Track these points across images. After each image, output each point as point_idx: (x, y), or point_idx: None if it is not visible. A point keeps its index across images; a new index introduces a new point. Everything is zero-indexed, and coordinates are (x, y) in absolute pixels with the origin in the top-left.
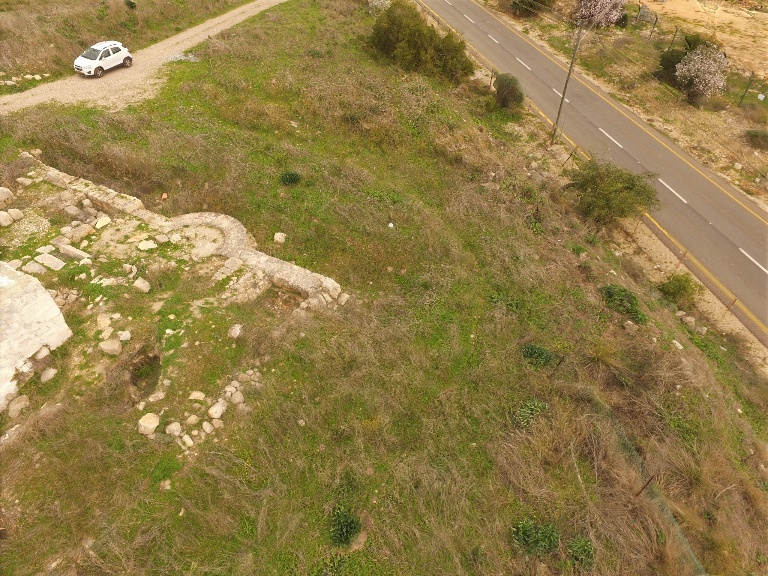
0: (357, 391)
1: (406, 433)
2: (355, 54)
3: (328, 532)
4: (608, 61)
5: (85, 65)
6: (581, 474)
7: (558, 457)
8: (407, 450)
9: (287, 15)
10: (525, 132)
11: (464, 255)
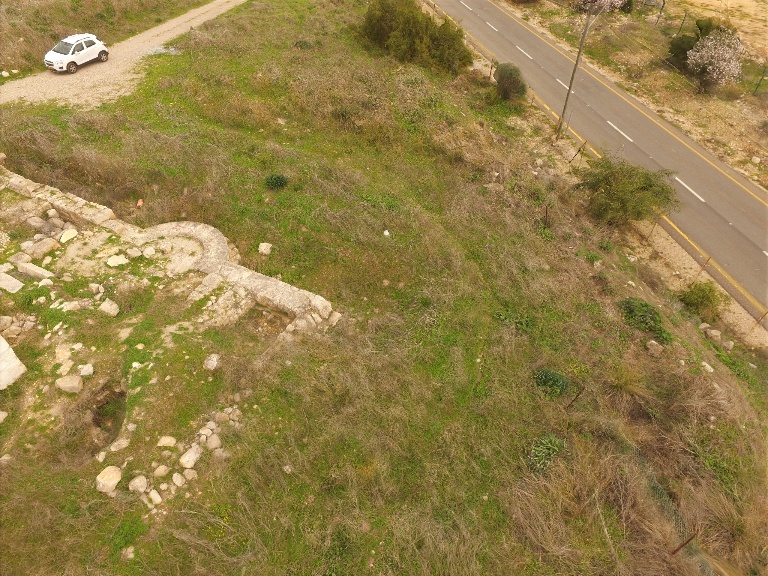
0: (350, 430)
1: (406, 480)
2: (346, 44)
3: None
4: (613, 48)
5: (56, 60)
6: (607, 525)
7: (581, 507)
8: (408, 500)
9: (274, 4)
10: (528, 126)
11: (467, 266)
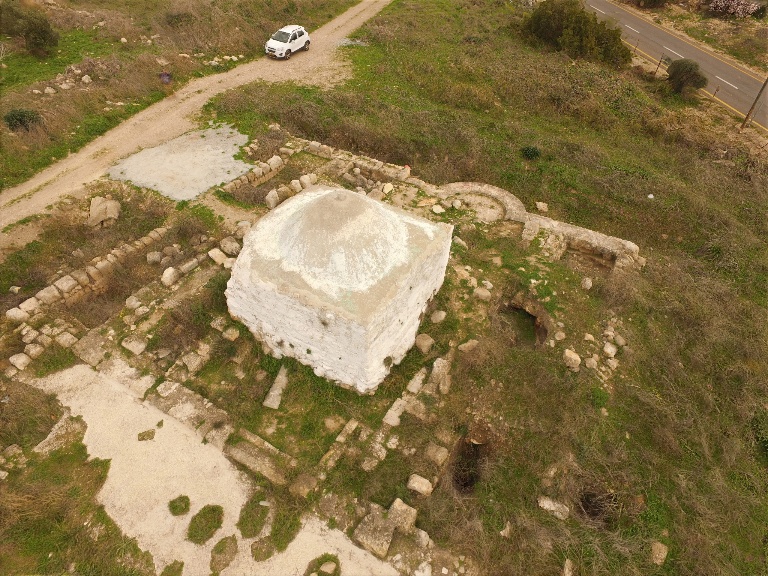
0: None
1: None
2: (511, 41)
3: (764, 457)
4: (758, 50)
5: (278, 47)
6: None
7: None
8: None
9: (423, 4)
10: (708, 116)
11: None
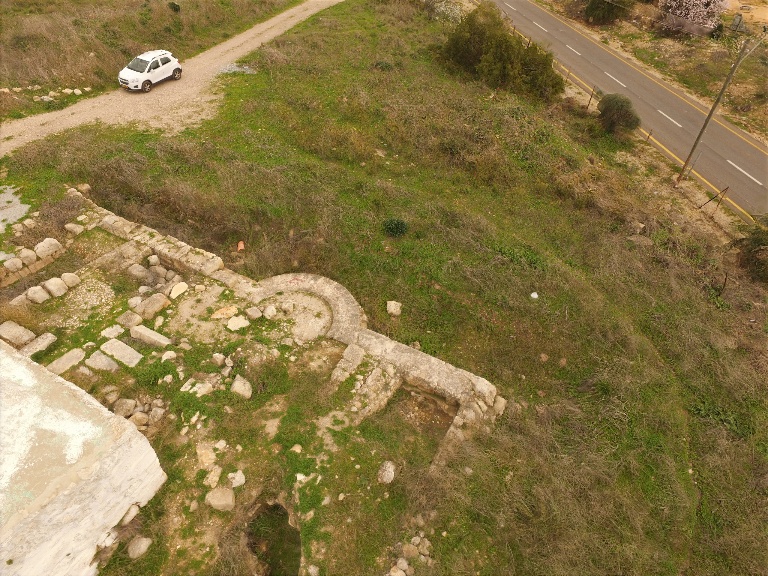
0: (569, 572)
1: None
2: (427, 66)
3: None
4: (711, 78)
5: (132, 78)
6: None
7: None
8: None
9: (342, 20)
10: (641, 163)
11: (640, 341)
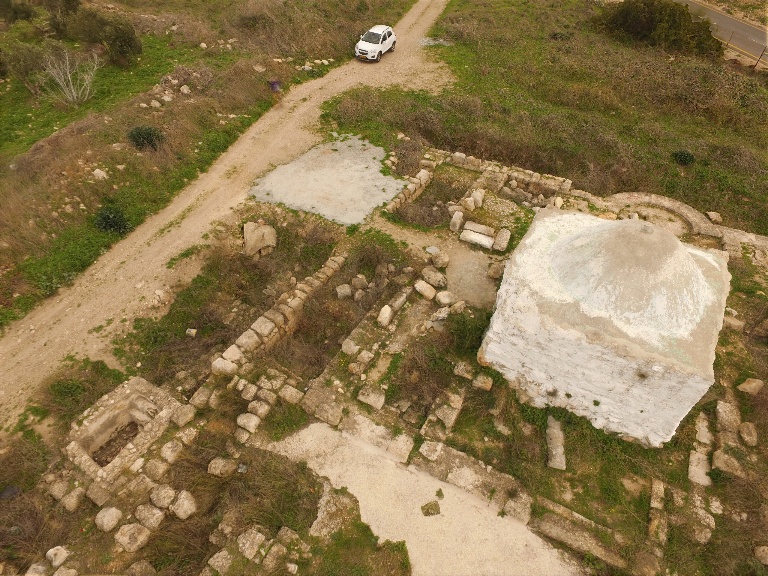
0: None
1: None
2: (595, 36)
3: None
4: None
5: (371, 49)
6: None
7: None
8: None
9: None
10: None
11: None
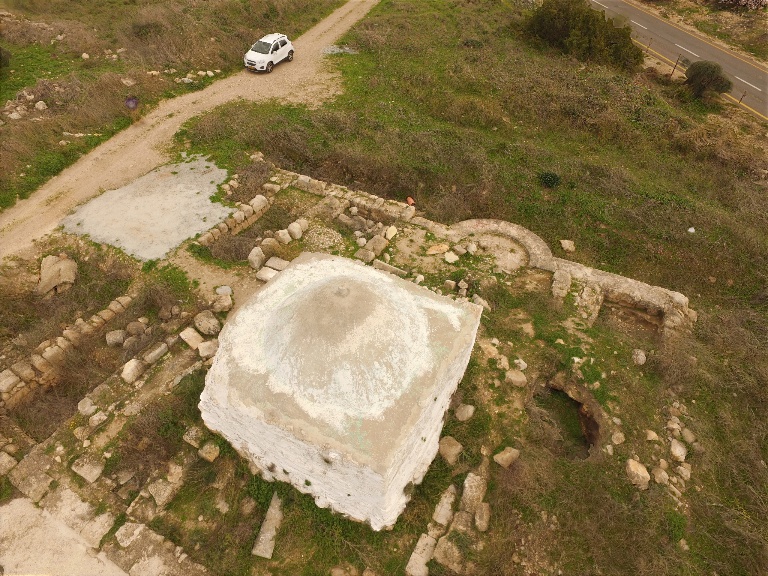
0: None
1: None
2: (512, 43)
3: None
4: None
5: (259, 60)
6: None
7: None
8: None
9: (414, 3)
10: (733, 124)
11: None
